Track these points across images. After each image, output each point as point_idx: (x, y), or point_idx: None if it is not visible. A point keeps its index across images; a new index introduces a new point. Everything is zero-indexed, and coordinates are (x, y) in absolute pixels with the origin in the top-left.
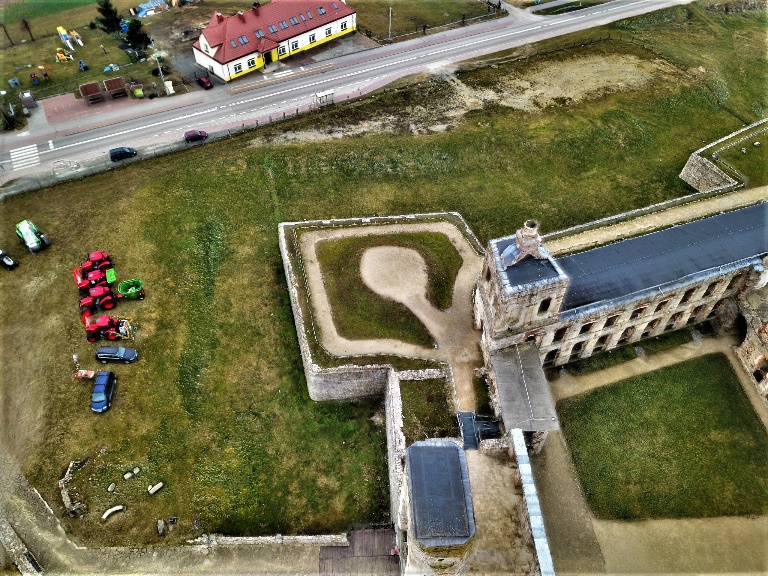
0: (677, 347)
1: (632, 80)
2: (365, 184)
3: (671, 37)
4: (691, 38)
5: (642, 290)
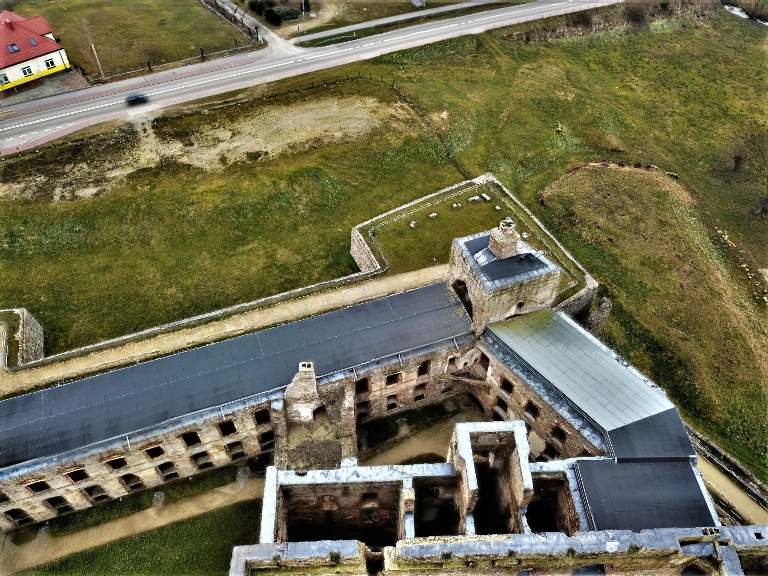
0: (208, 492)
1: (353, 129)
2: None
3: (444, 72)
4: (467, 73)
5: (99, 442)
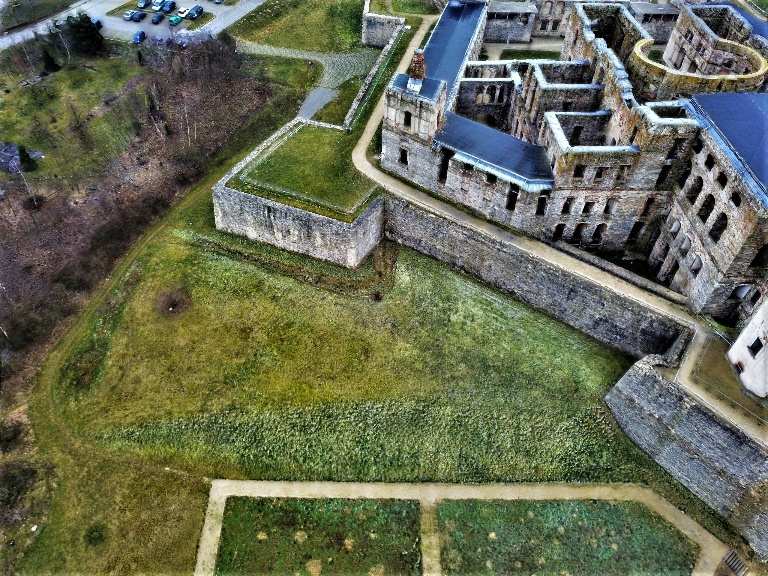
0: None
1: None
2: None
3: None
4: None
5: None
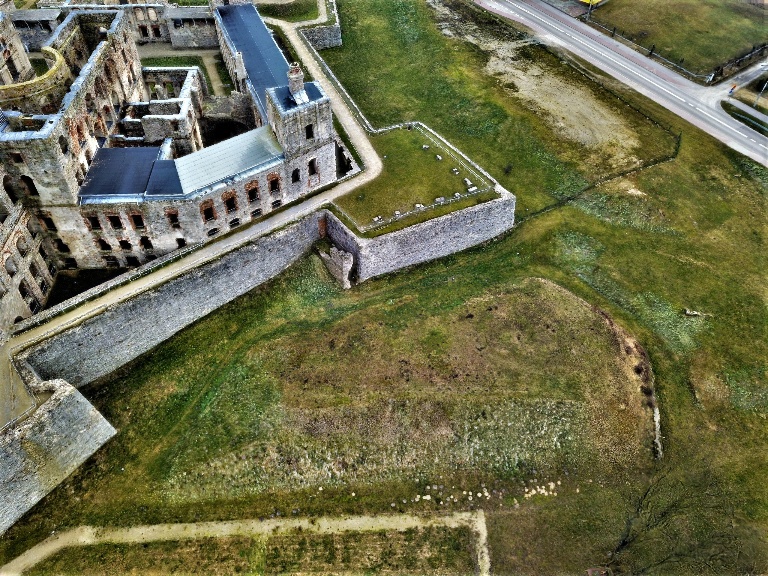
0: None
1: (573, 132)
2: (386, 17)
3: (760, 214)
4: None
5: (226, 29)
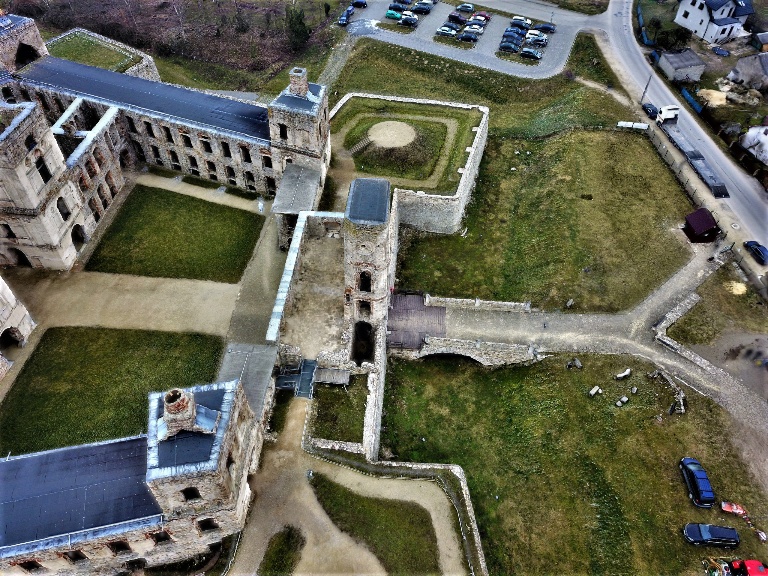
0: None
1: None
2: None
3: None
4: None
5: (33, 456)
